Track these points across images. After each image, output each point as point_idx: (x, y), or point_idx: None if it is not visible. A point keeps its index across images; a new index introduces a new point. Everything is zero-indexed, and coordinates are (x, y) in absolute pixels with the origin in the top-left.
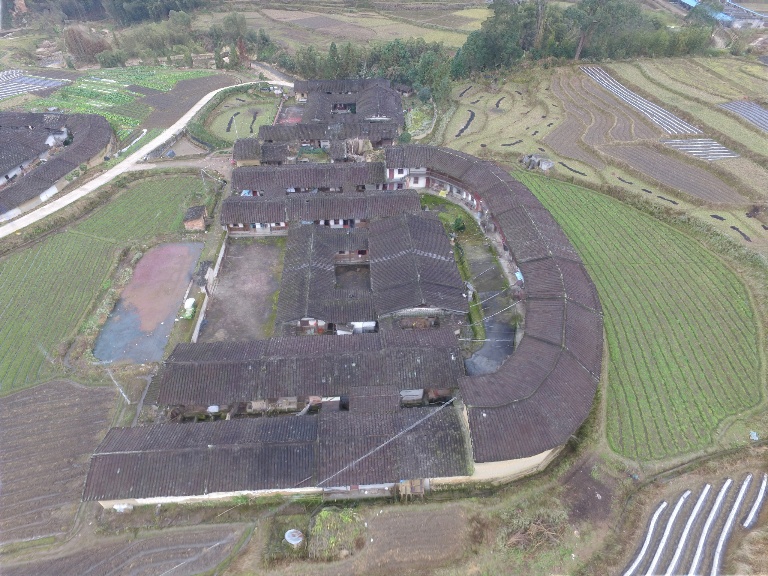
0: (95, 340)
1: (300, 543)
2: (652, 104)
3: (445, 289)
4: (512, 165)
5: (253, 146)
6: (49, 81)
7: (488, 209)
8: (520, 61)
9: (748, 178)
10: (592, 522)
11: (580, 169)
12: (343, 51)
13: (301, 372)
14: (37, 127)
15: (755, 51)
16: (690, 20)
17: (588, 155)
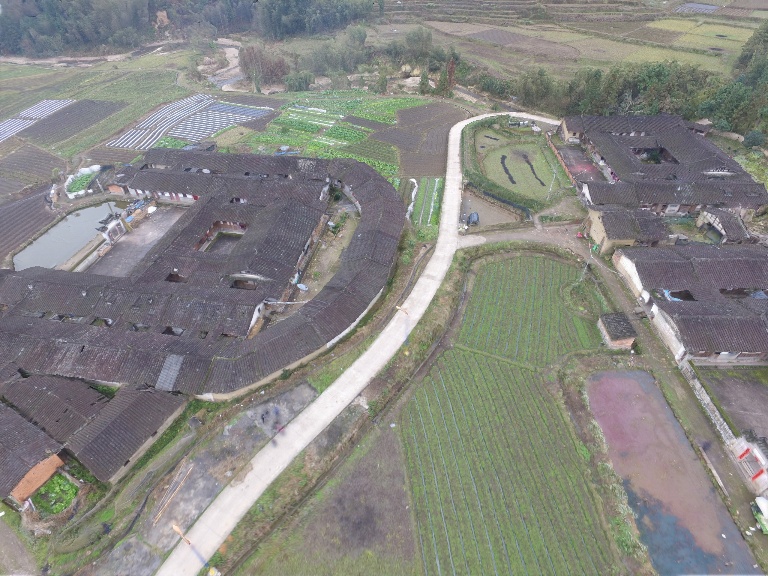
0: (655, 570)
1: None
2: None
3: None
4: None
5: (627, 220)
6: (250, 109)
7: None
8: None
9: None
10: None
11: None
12: (585, 76)
13: None
14: (296, 176)
15: None
16: None
17: None
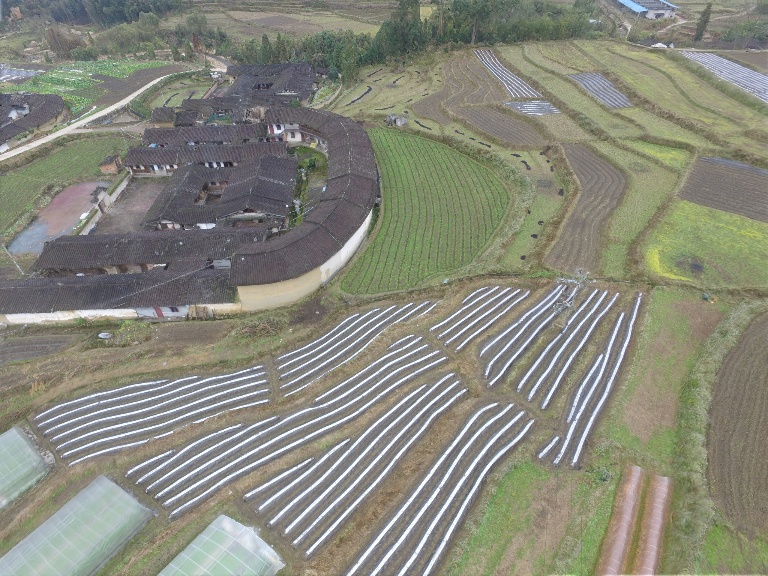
0: (10, 240)
1: (111, 342)
2: (515, 76)
3: (272, 201)
4: (377, 124)
5: (168, 112)
6: (26, 72)
7: (327, 149)
8: (426, 46)
9: (554, 127)
10: (305, 325)
11: (429, 125)
12: None
13: (142, 248)
14: (4, 104)
15: (658, 37)
16: (577, 8)
17: (441, 115)
